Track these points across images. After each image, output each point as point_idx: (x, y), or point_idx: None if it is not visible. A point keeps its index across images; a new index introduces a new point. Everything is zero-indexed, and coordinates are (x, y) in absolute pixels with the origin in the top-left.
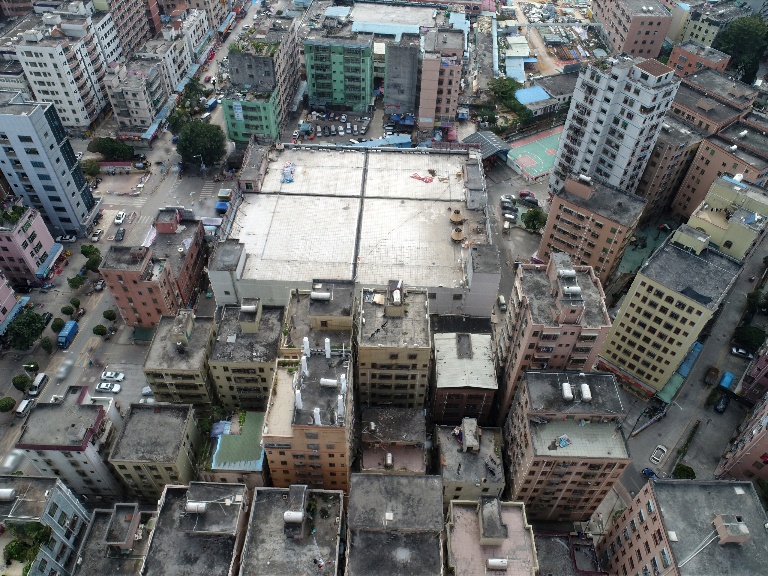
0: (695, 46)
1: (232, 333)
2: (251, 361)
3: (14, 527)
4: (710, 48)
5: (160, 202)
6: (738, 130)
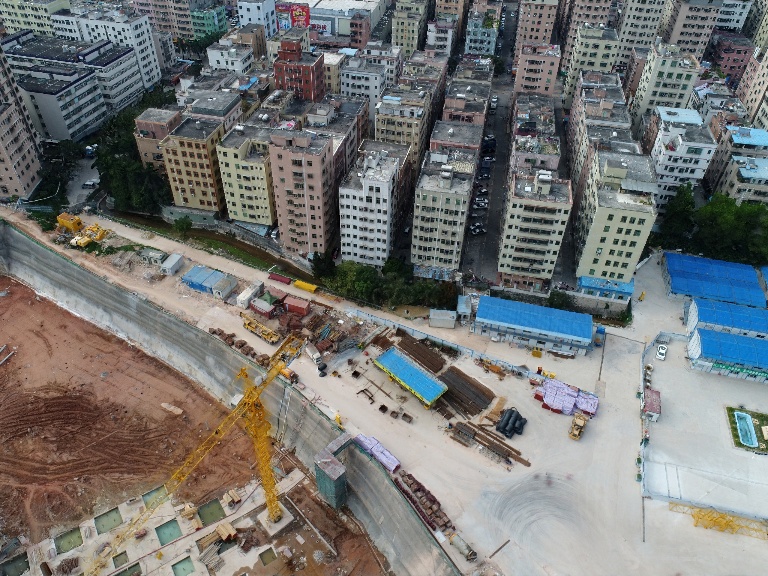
0: None
1: None
2: (424, 2)
3: (485, 16)
4: None
5: None
6: None
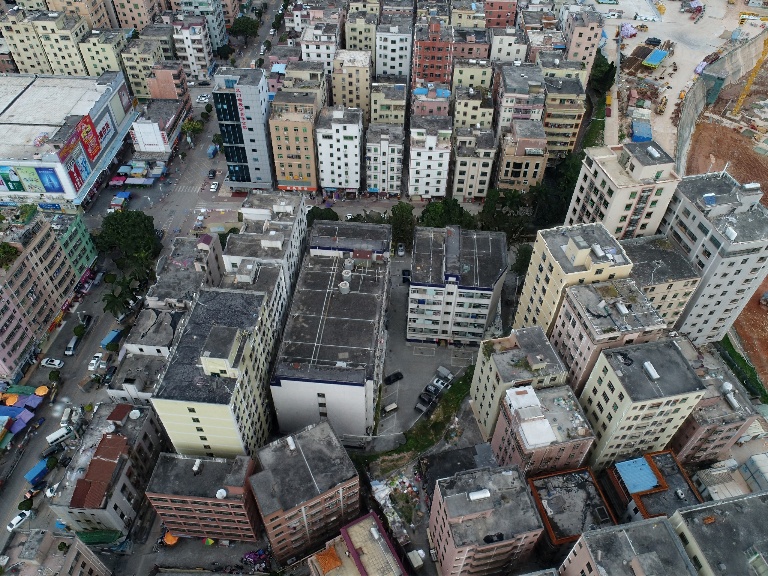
0: None
1: (110, 39)
2: None
3: None
4: None
5: (182, 205)
6: None
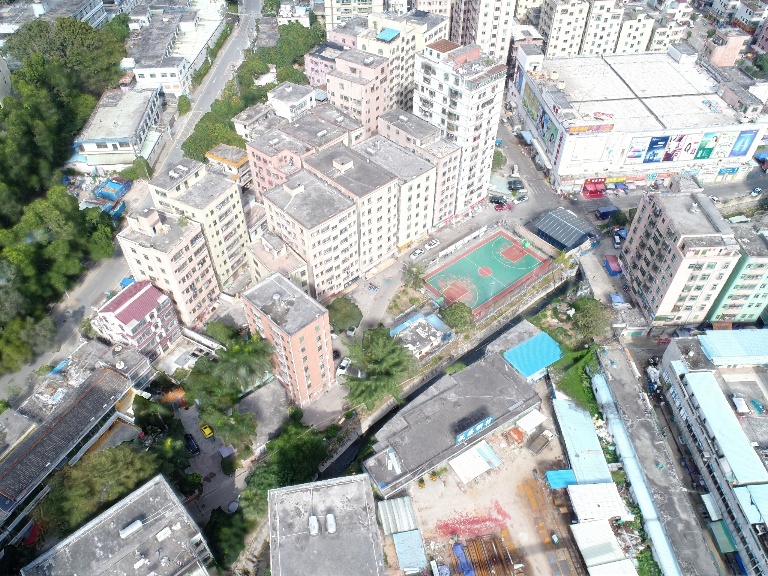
0: (285, 328)
1: None
2: None
3: None
4: (265, 314)
5: None
6: (321, 143)
